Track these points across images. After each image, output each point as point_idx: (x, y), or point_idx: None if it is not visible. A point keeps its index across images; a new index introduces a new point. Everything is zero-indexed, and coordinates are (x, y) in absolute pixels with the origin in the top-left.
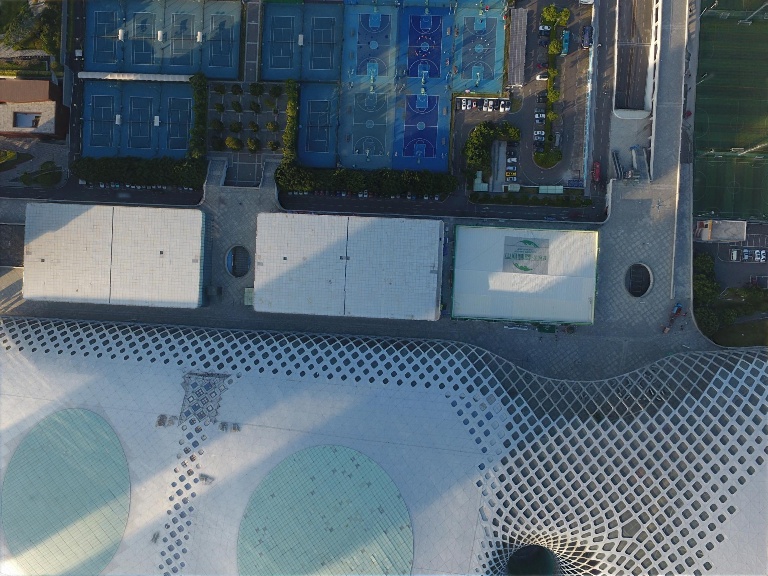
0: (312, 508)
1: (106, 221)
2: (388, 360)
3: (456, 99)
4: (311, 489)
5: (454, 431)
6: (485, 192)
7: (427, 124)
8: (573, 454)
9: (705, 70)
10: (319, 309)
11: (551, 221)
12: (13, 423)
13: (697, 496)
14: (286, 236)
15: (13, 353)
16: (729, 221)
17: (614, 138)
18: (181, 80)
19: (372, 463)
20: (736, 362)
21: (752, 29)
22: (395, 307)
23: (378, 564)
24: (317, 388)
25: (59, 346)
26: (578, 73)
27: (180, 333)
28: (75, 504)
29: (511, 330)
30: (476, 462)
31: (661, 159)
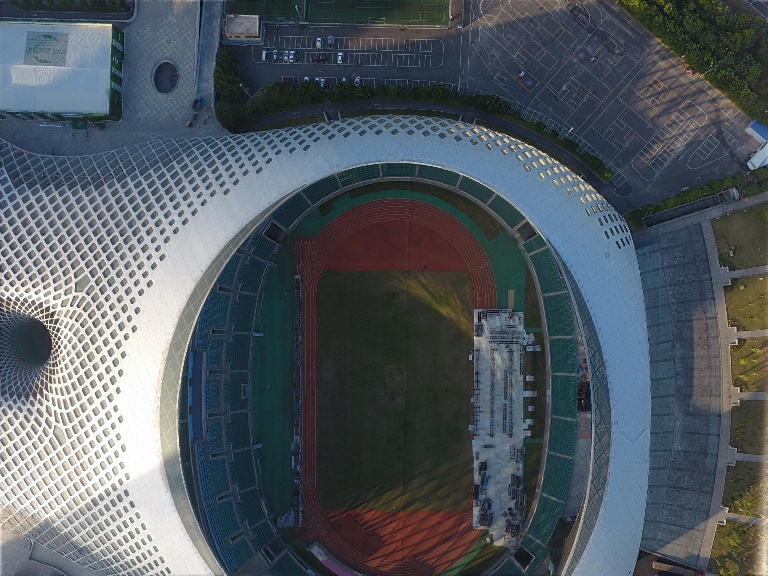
0: None
1: None
2: None
3: None
4: None
5: None
6: None
7: None
8: (41, 218)
9: None
10: None
11: (79, 20)
12: None
13: (138, 248)
14: None
15: None
16: (243, 16)
17: None
18: None
19: None
20: (219, 138)
21: None
22: None
23: None
24: None
25: None
26: None
27: None
28: None
29: (46, 128)
30: None
31: None
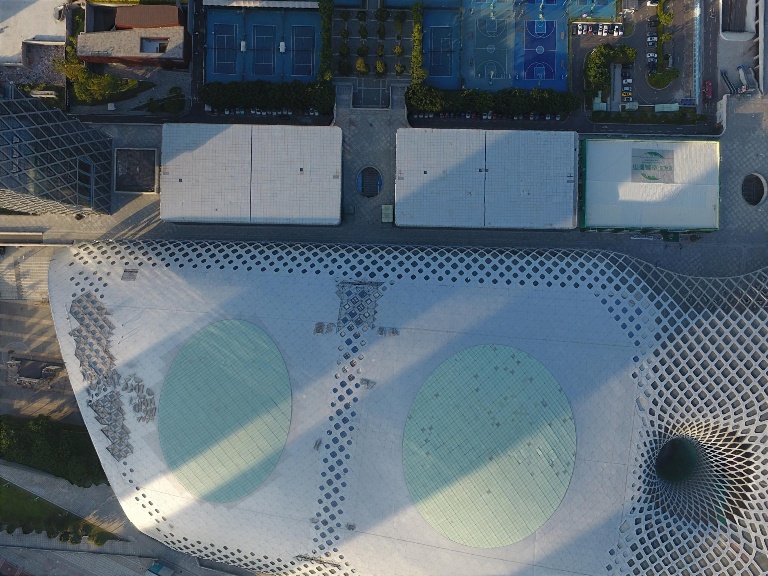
0: (478, 404)
1: (245, 140)
2: (534, 265)
3: (572, 24)
4: (475, 386)
5: (607, 327)
6: (605, 111)
7: (546, 48)
8: (720, 344)
9: None
10: (460, 221)
11: (672, 135)
12: (167, 336)
13: None
14: (426, 150)
15: (160, 269)
16: None
17: (722, 59)
18: (307, 7)
19: (532, 359)
20: None
21: None
22: (534, 216)
23: (544, 456)
24: (470, 292)
25: (206, 261)
26: None
27: (325, 247)
28: (236, 414)
29: (637, 240)
30: (630, 355)
31: None
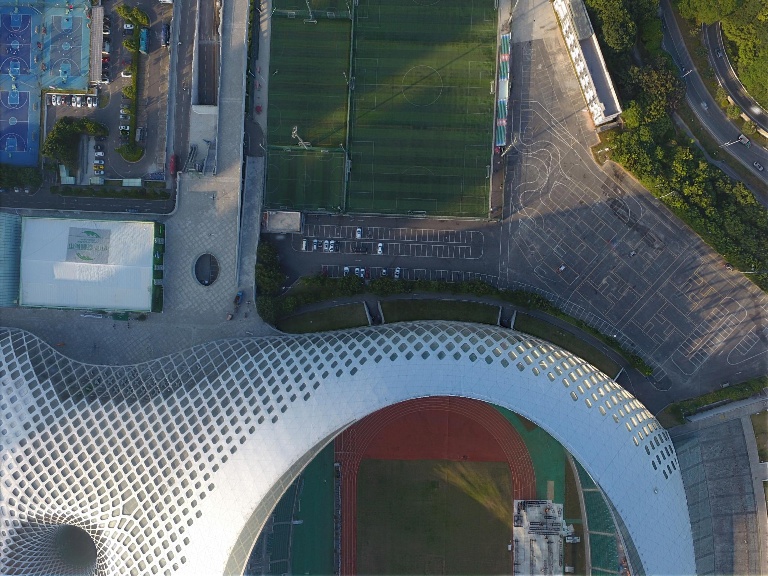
0: None
1: None
2: None
3: (47, 95)
4: None
5: None
6: (70, 185)
7: (18, 119)
8: (88, 436)
9: (276, 67)
10: None
11: (121, 213)
12: None
13: (187, 474)
14: None
15: None
16: (284, 212)
17: (193, 133)
18: None
19: None
20: (263, 347)
21: (317, 28)
22: None
23: None
24: None
25: None
26: (161, 70)
27: None
28: None
29: (87, 318)
30: None
31: (225, 153)
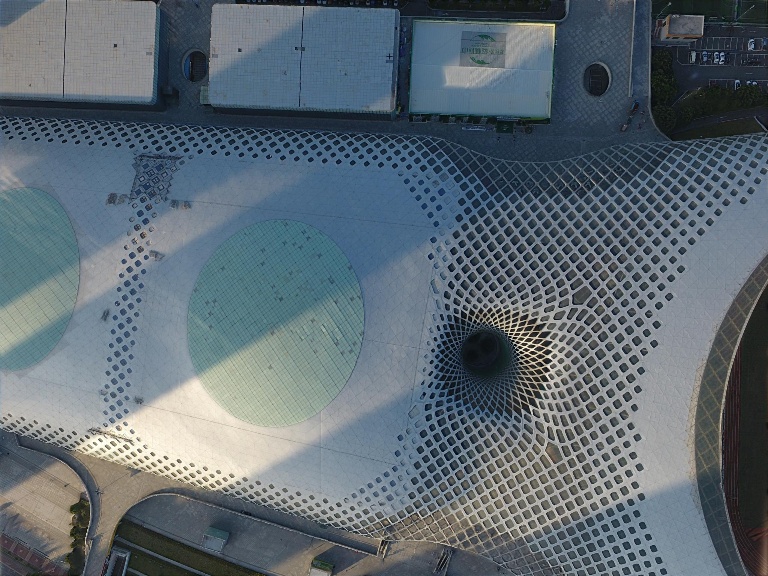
0: (262, 278)
1: (59, 14)
2: (342, 144)
3: None
4: (261, 260)
5: (406, 206)
6: None
7: None
8: (525, 227)
9: None
10: (274, 101)
11: (509, 19)
12: None
13: (647, 259)
14: (241, 27)
15: None
16: (687, 16)
17: None
18: None
19: (323, 236)
20: (691, 144)
21: None
22: (350, 98)
23: (328, 334)
24: (269, 168)
25: (10, 133)
26: None
27: (133, 124)
28: (24, 281)
29: (469, 131)
30: (428, 235)
31: None
